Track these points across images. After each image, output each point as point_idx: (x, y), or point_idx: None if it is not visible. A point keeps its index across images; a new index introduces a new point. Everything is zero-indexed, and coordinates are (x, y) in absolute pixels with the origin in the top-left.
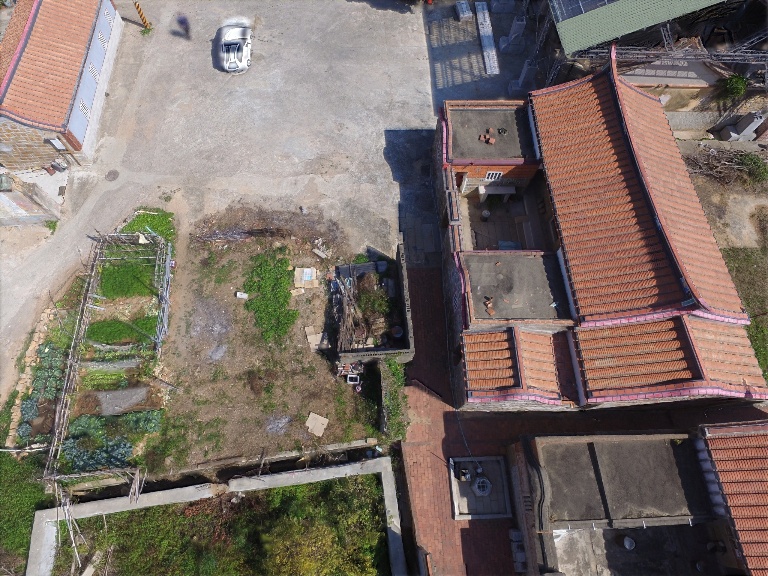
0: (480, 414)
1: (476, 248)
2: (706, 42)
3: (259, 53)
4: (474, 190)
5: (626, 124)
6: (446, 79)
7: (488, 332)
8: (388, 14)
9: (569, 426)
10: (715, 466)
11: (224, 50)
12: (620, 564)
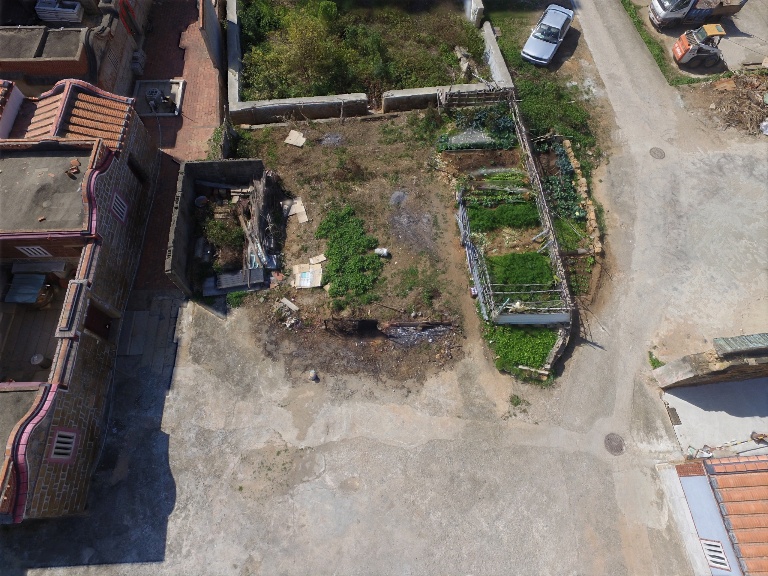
0: None
1: None
2: None
3: None
4: None
5: None
6: None
7: None
8: None
9: None
10: None
11: None
12: None
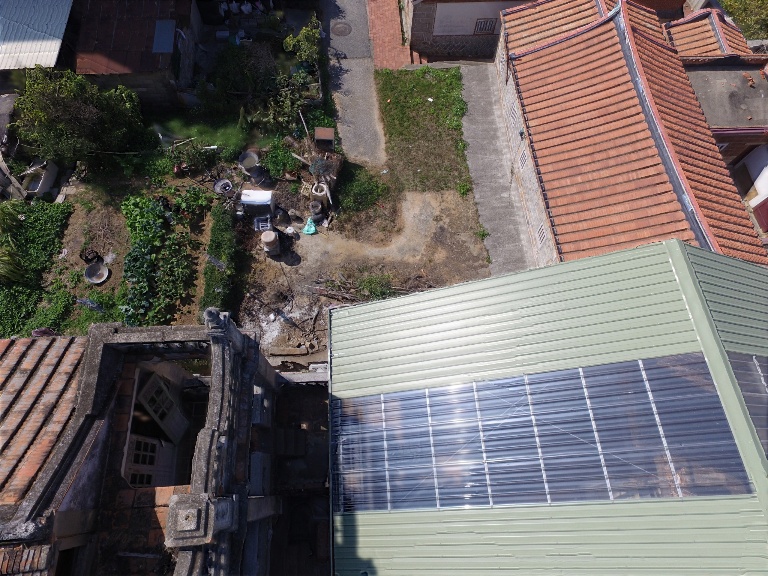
0: None
1: None
2: None
3: None
4: None
5: None
6: None
7: None
8: None
9: None
10: None
11: None
12: None
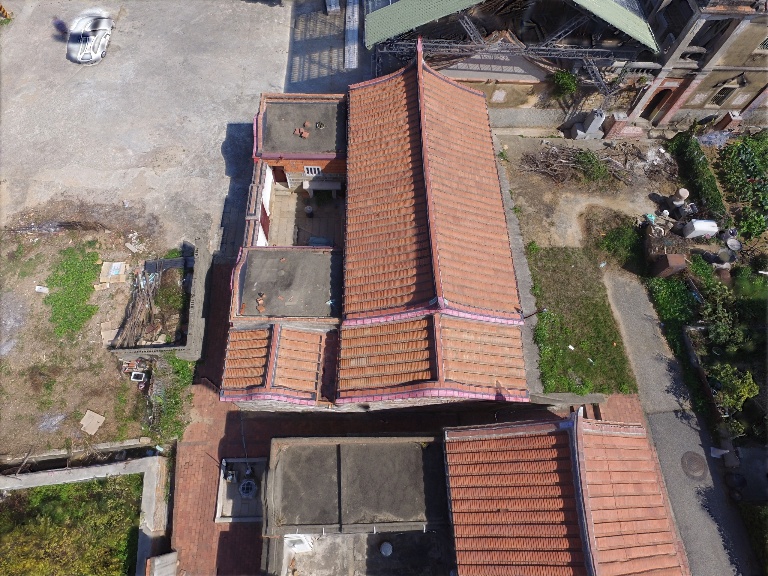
0: (264, 414)
1: (296, 244)
2: (522, 36)
3: (116, 44)
4: (301, 185)
5: (421, 118)
6: (302, 73)
7: (254, 329)
8: (256, 7)
9: (354, 427)
10: (448, 470)
11: (81, 41)
12: (379, 570)
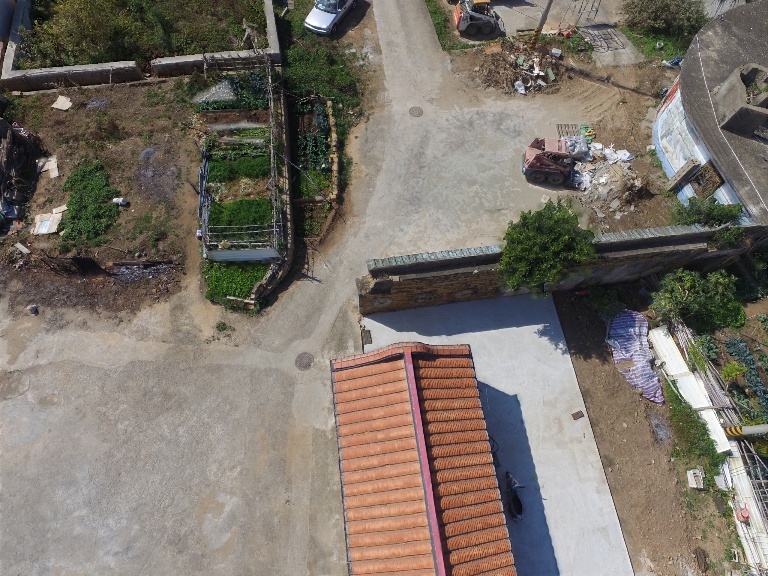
0: None
1: None
2: None
3: None
4: None
5: None
6: None
7: None
8: None
9: None
10: None
11: None
12: None
